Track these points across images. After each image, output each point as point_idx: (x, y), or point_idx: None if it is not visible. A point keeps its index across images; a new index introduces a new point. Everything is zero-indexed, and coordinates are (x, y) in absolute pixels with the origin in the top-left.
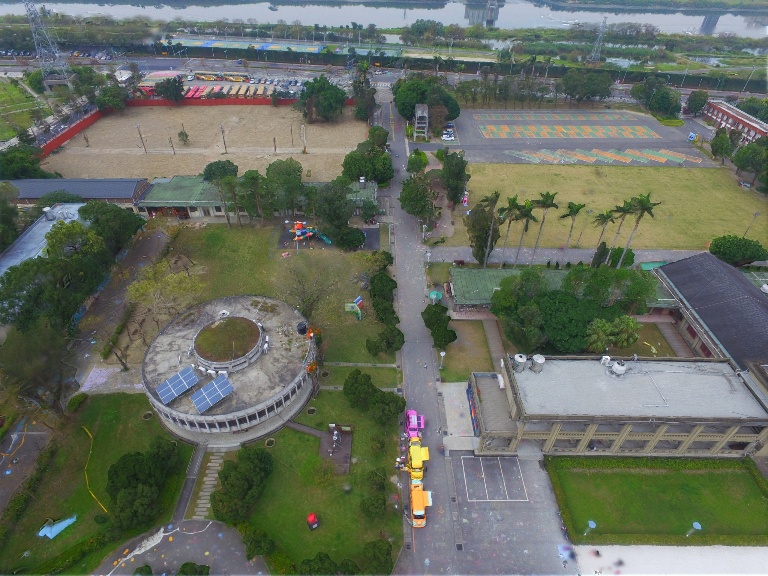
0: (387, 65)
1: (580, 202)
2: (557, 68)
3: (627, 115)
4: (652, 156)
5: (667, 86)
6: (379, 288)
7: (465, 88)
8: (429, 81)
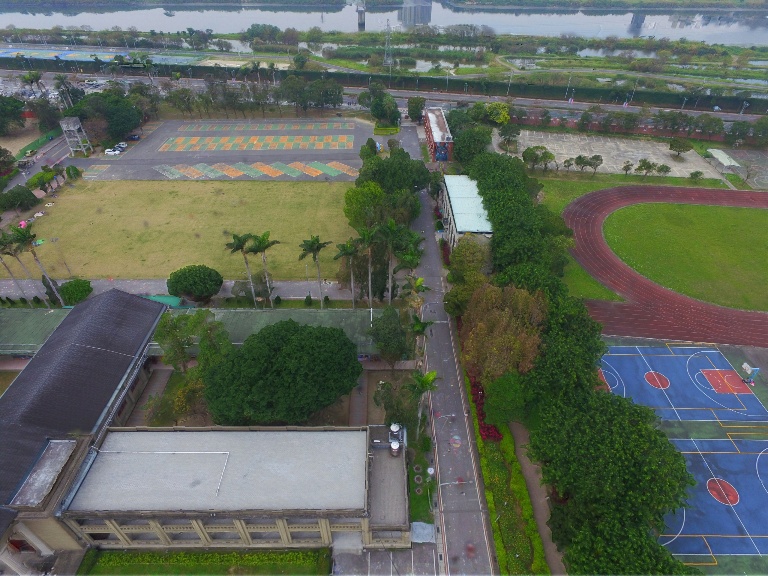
0: (95, 74)
1: (151, 224)
2: (322, 74)
3: (350, 123)
4: (311, 169)
5: (387, 92)
6: None
7: (172, 98)
8: (131, 91)
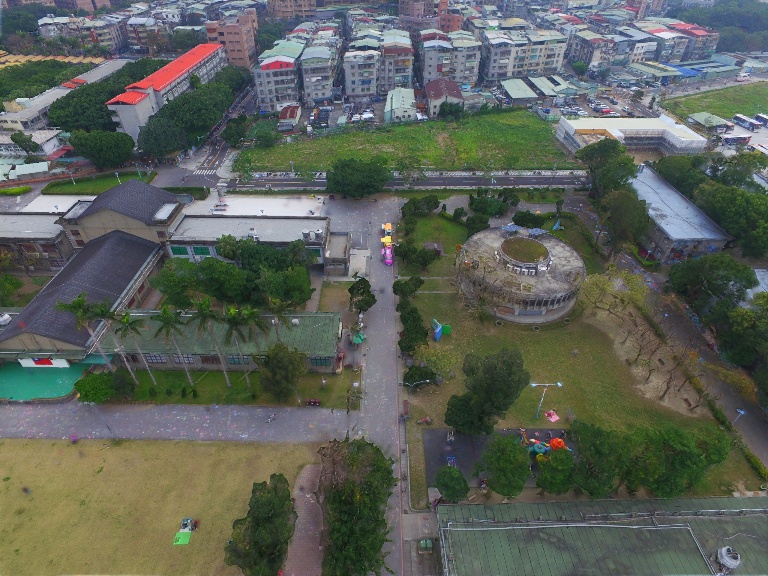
0: None
1: None
2: None
3: None
4: None
5: None
6: None
7: None
8: None
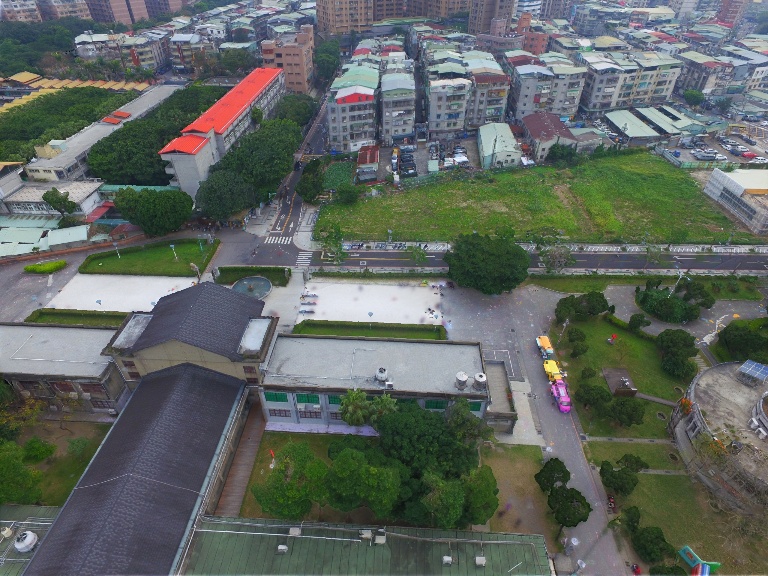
0: None
1: None
2: None
3: None
4: None
5: None
6: (681, 570)
7: None
8: None
